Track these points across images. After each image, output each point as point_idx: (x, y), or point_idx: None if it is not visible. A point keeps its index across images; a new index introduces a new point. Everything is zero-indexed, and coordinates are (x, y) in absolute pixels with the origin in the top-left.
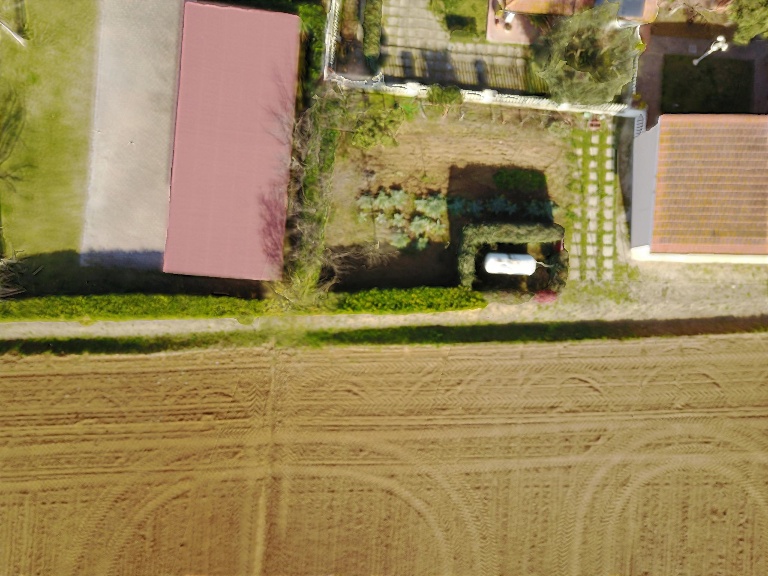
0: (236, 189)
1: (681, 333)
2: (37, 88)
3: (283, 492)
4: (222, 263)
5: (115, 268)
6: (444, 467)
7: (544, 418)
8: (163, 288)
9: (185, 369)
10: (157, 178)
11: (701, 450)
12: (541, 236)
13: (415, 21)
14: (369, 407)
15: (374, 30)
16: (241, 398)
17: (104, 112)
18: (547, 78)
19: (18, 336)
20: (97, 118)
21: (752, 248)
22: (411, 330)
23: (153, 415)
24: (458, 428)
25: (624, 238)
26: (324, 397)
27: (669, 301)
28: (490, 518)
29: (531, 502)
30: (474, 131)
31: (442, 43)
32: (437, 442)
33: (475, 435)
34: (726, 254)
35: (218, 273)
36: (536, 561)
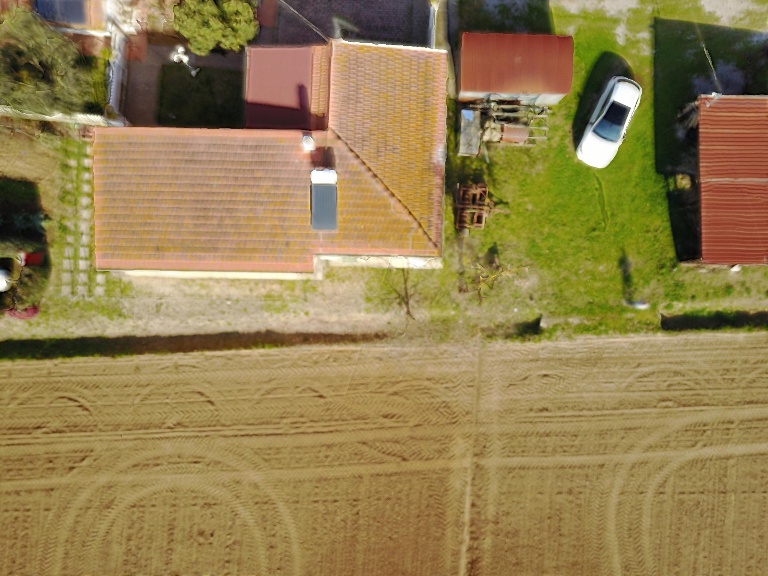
0: None
1: (177, 350)
2: None
3: None
4: None
5: None
6: None
7: (29, 439)
8: None
9: None
10: None
11: (191, 470)
12: None
13: None
14: None
15: None
16: None
17: None
18: None
19: None
20: None
21: (199, 264)
22: None
23: None
24: None
25: None
26: None
27: (164, 317)
28: None
29: (10, 527)
30: None
31: None
32: None
33: None
34: (172, 270)
35: None
36: None
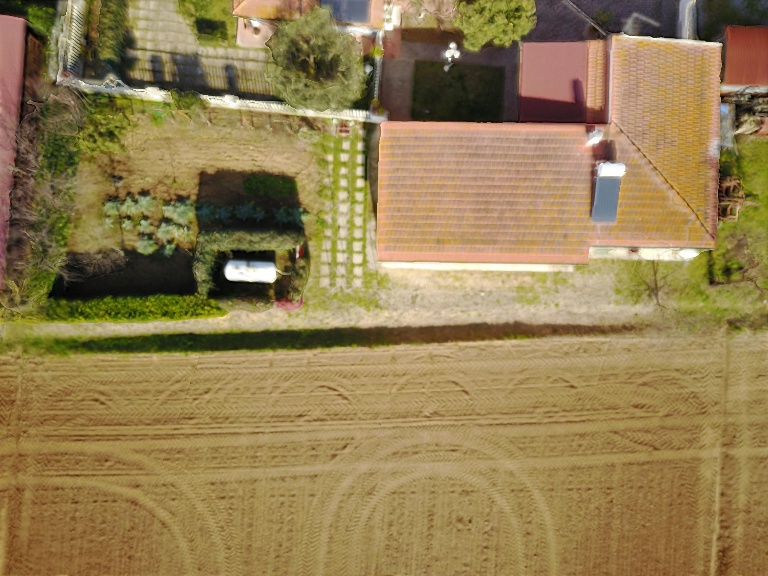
0: None
1: (431, 341)
2: None
3: (26, 504)
4: None
5: None
6: (189, 477)
7: (292, 427)
8: None
9: None
10: None
11: (448, 458)
12: (275, 244)
13: (165, 24)
14: (116, 417)
15: (108, 34)
16: None
17: None
18: (275, 84)
19: None
20: None
21: (477, 256)
22: (162, 338)
23: None
24: (205, 437)
25: (374, 245)
26: (71, 407)
27: (419, 309)
28: (235, 528)
29: (276, 512)
30: (224, 137)
31: (192, 47)
32: (183, 452)
33: (222, 444)
34: (451, 262)
35: None
36: (280, 571)
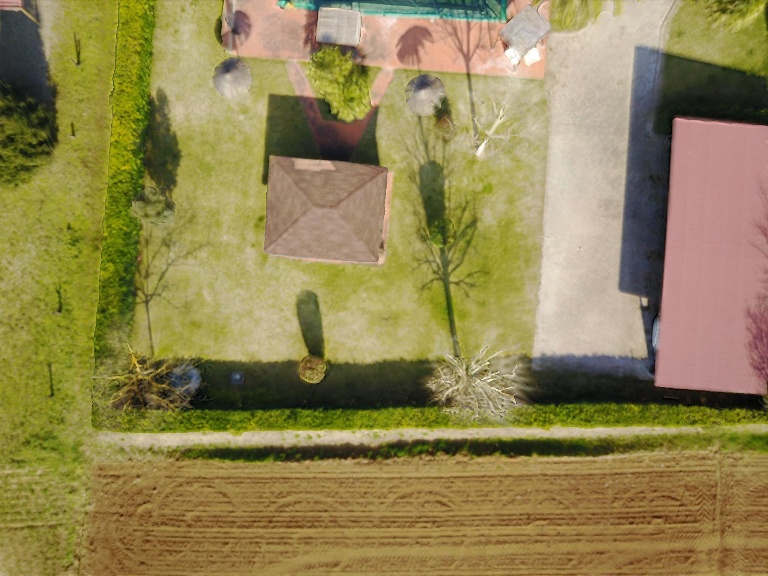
0: (723, 303)
1: None
2: (487, 195)
3: None
4: (709, 376)
5: (566, 372)
6: None
7: None
8: (613, 392)
9: (631, 471)
10: (605, 283)
11: None
12: None
13: None
14: None
15: None
16: (688, 502)
17: (552, 218)
18: None
19: (463, 435)
20: (545, 224)
21: None
22: None
23: (603, 518)
24: None
25: None
26: None
27: None
28: None
29: None
30: None
31: None
32: None
33: None
34: None
35: (706, 387)
36: None
